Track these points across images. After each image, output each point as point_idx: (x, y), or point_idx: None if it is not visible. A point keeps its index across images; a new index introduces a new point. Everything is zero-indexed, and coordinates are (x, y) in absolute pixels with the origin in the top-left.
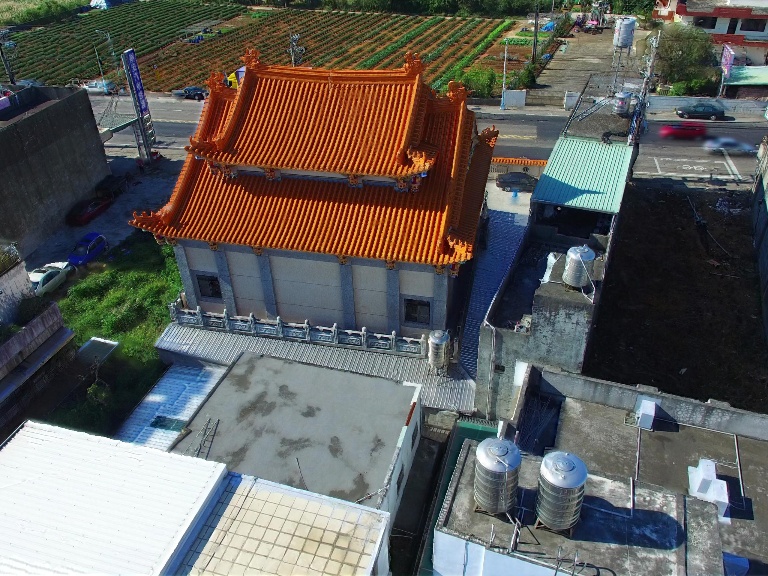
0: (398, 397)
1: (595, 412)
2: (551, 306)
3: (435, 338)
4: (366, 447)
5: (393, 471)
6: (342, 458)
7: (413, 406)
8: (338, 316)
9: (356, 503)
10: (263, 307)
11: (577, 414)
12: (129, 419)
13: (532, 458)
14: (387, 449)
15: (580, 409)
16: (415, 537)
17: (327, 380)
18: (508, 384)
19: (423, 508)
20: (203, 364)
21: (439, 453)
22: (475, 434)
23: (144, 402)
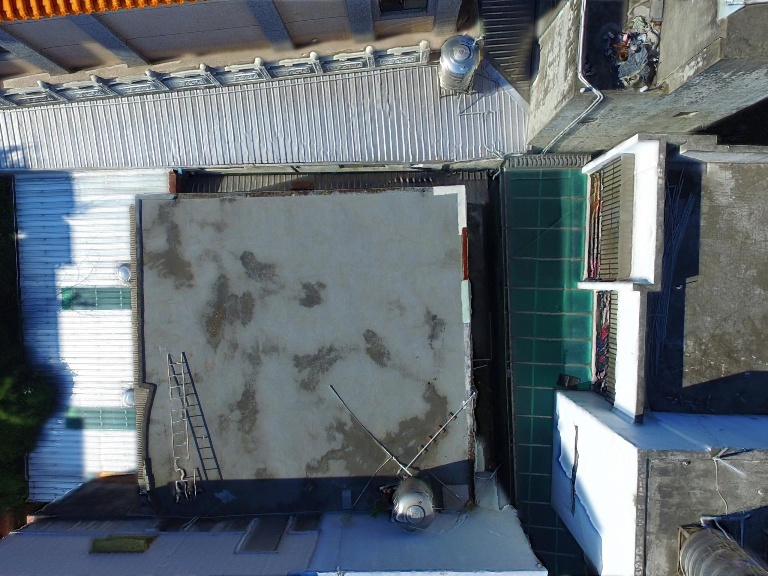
0: (434, 223)
1: (755, 183)
2: (743, 68)
3: (456, 65)
4: (420, 336)
5: (472, 367)
6: (393, 366)
7: (464, 237)
8: (252, 32)
9: (497, 573)
10: (103, 48)
11: (727, 196)
12: (24, 304)
13: (745, 458)
14: (451, 331)
15: (732, 184)
16: (491, 364)
17: (309, 221)
18: (595, 128)
19: (489, 320)
20: (65, 172)
21: (487, 226)
22: (535, 189)
23: (23, 268)
